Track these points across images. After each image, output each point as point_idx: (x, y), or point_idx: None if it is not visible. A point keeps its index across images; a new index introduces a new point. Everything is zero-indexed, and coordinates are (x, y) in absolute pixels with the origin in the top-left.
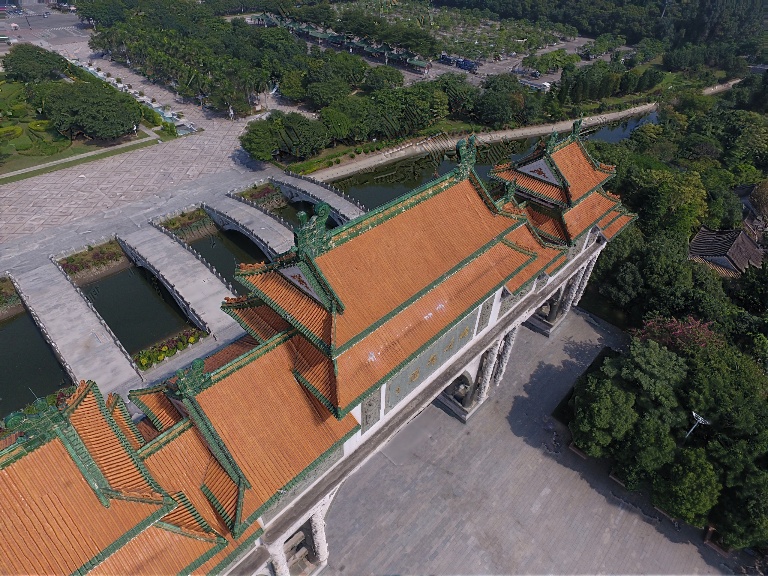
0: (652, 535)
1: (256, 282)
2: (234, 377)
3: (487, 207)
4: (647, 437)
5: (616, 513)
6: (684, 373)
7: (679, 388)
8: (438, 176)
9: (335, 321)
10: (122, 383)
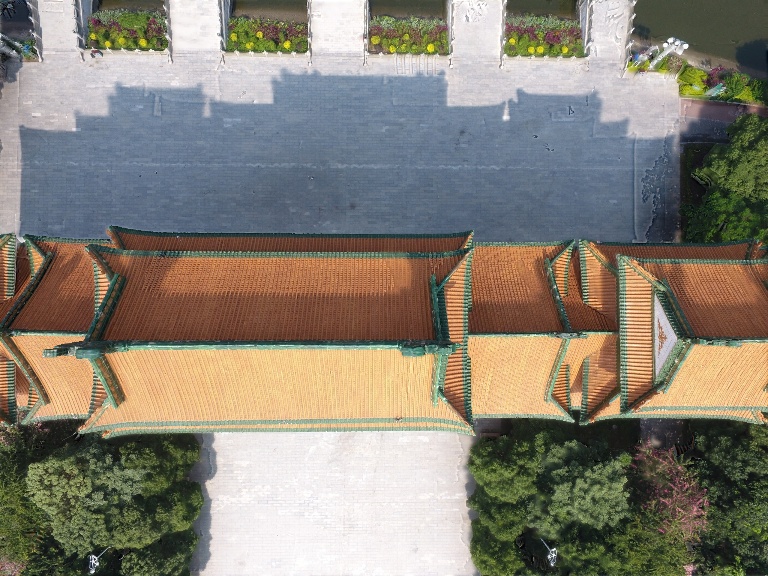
0: (455, 525)
1: (100, 275)
2: (53, 337)
3: (431, 386)
4: (499, 518)
5: (451, 494)
6: (599, 528)
7: (581, 525)
8: (451, 273)
9: (107, 405)
10: (204, 50)
